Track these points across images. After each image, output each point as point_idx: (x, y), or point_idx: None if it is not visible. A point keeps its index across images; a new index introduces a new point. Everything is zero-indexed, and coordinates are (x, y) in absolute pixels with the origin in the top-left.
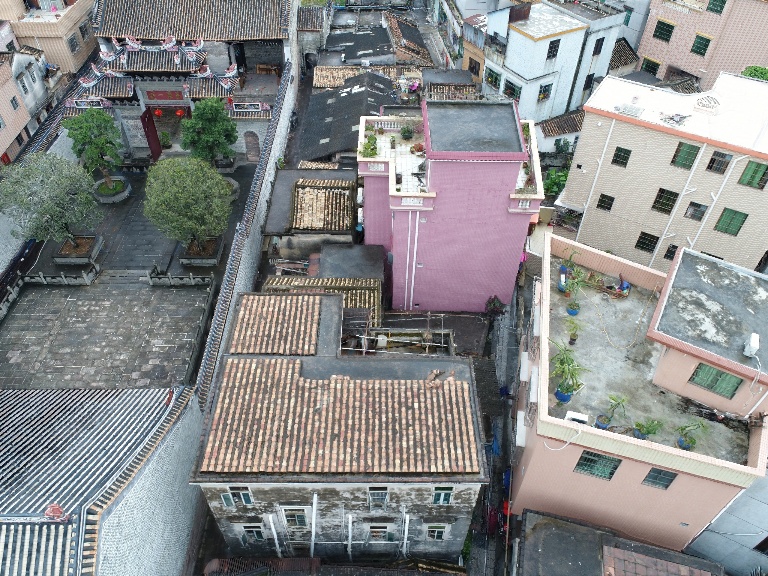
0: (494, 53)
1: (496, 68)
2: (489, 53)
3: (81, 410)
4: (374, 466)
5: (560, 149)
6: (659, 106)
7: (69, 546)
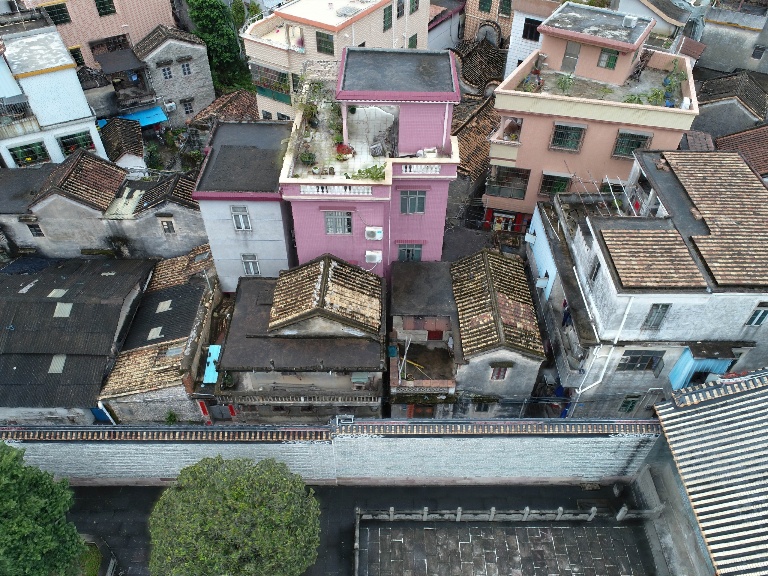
0: (12, 125)
1: (27, 140)
2: (2, 131)
3: (762, 499)
4: (767, 195)
5: (152, 160)
6: (339, 1)
7: None
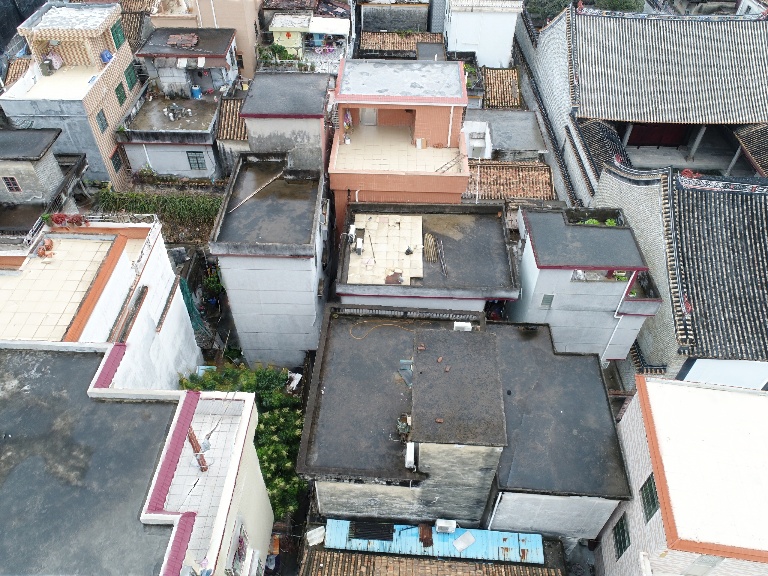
0: None
1: None
2: None
3: None
4: None
5: None
6: None
7: (765, 27)
